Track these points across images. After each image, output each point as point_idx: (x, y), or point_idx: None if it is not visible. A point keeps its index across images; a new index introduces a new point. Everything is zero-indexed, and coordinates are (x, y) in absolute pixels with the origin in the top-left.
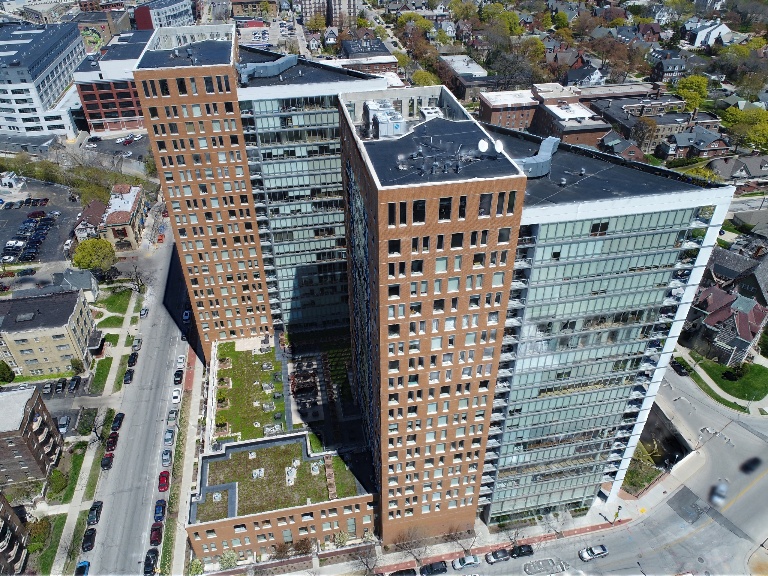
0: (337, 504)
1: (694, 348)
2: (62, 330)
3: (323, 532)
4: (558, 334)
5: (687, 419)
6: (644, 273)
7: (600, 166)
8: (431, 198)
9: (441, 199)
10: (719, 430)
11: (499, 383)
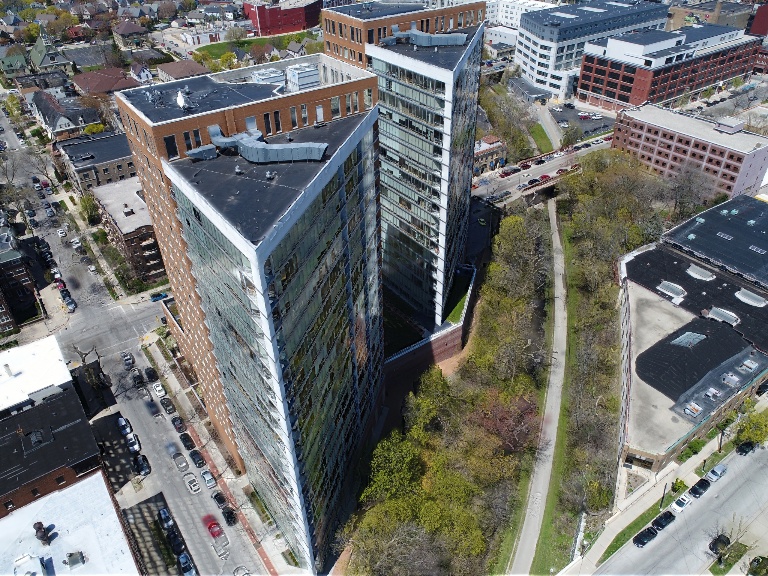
0: None
1: None
2: None
3: None
4: None
5: None
6: None
7: (300, 185)
8: (128, 114)
9: None
10: None
11: None
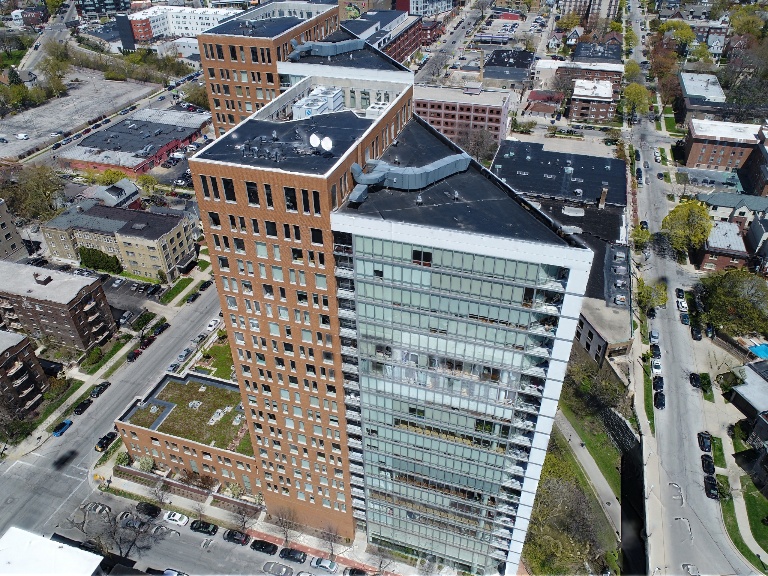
0: (230, 455)
1: (750, 473)
2: (154, 244)
3: (223, 477)
4: (401, 363)
5: (675, 545)
6: (489, 325)
7: (491, 195)
8: (236, 179)
9: (247, 182)
10: (708, 575)
11: (353, 395)
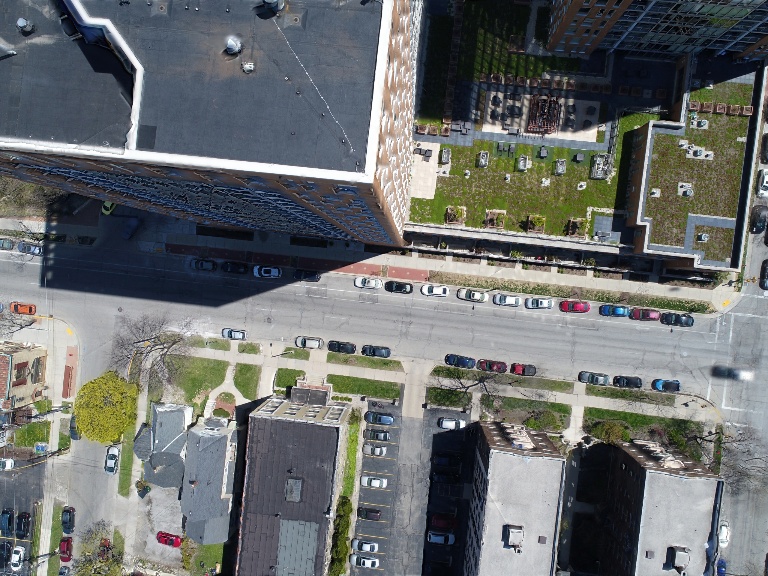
0: None
1: None
2: (340, 435)
3: None
4: None
5: None
6: None
7: None
8: None
9: None
10: None
11: None
